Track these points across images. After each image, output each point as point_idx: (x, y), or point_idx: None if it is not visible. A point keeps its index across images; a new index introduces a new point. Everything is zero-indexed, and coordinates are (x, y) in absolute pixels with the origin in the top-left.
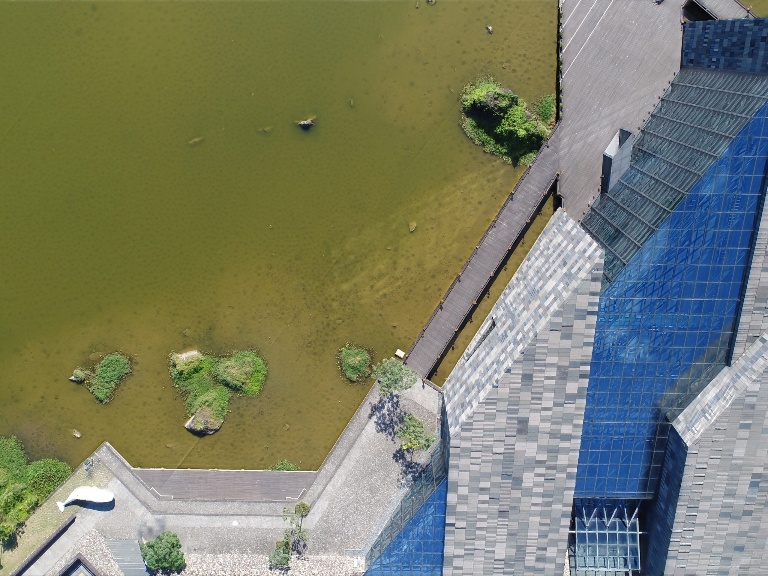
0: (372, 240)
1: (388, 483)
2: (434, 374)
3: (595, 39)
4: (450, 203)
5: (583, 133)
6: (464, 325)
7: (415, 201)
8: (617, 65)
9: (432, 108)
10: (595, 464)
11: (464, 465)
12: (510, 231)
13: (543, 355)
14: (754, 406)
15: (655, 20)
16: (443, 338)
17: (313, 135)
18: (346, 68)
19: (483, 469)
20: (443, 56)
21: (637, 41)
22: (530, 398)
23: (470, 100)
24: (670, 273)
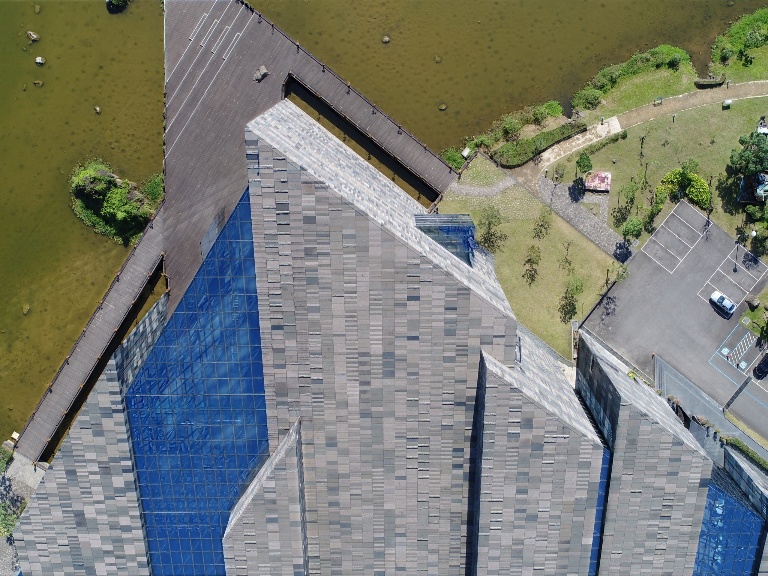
0: None
1: (3, 566)
2: (51, 455)
3: (197, 118)
4: (63, 284)
5: (187, 213)
6: (80, 406)
7: (28, 283)
8: (219, 144)
9: (42, 190)
10: (167, 552)
11: (33, 557)
12: (117, 312)
13: (81, 452)
14: (275, 501)
15: (256, 98)
16: (53, 421)
17: None
18: None
19: (53, 560)
20: (52, 138)
21: (239, 119)
22: (80, 492)
23: (75, 182)
24: (188, 371)
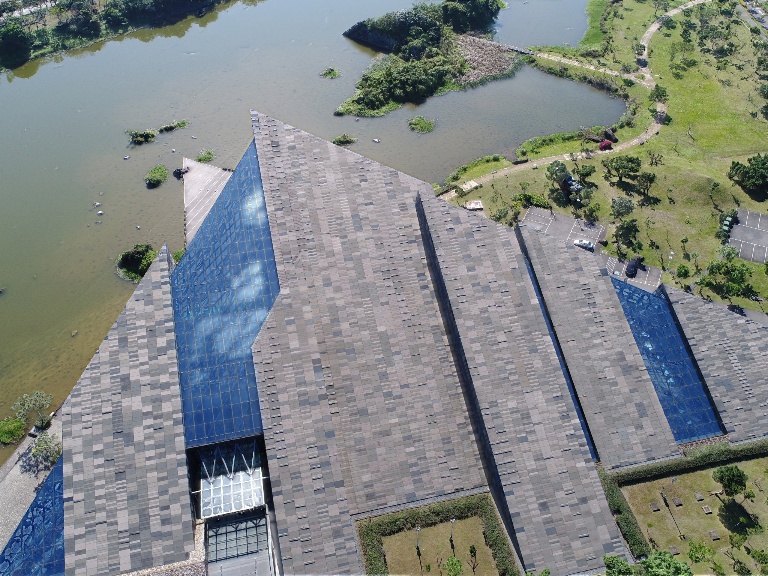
0: (40, 347)
1: None
2: None
3: None
4: (106, 315)
5: None
6: None
7: (78, 319)
8: None
9: (95, 269)
10: (200, 410)
11: (77, 431)
12: None
13: (133, 320)
14: (291, 305)
15: None
16: None
17: (2, 298)
18: (34, 261)
19: (95, 431)
20: (105, 244)
21: None
22: (128, 357)
23: (121, 257)
24: (218, 251)
